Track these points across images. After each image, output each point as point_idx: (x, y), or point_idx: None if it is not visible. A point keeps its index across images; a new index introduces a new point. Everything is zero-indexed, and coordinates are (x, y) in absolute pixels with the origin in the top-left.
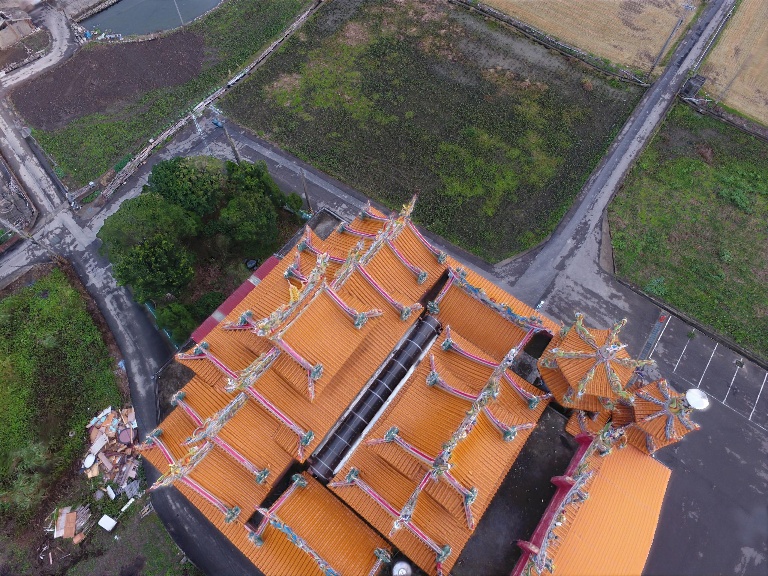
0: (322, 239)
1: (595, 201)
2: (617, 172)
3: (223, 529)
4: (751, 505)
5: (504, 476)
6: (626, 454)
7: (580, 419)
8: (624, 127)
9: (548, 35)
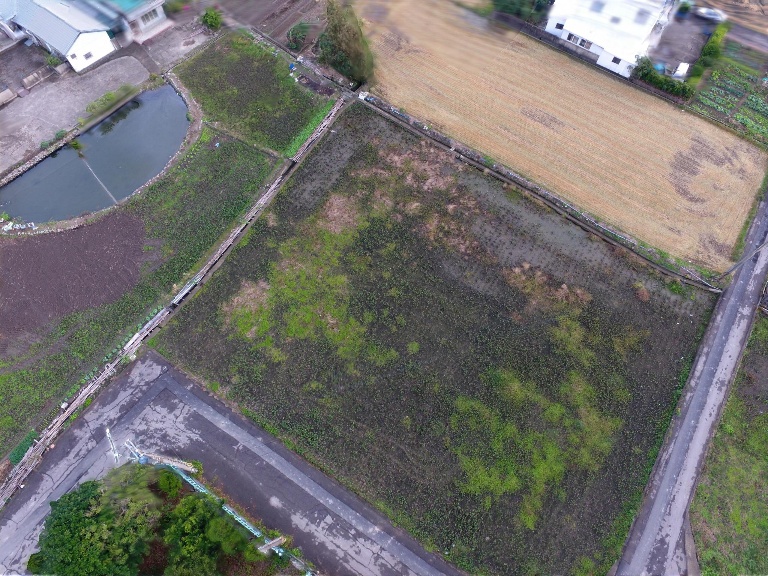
0: None
1: (672, 499)
2: (696, 445)
3: None
4: None
5: None
6: None
7: None
8: (696, 364)
9: (585, 213)
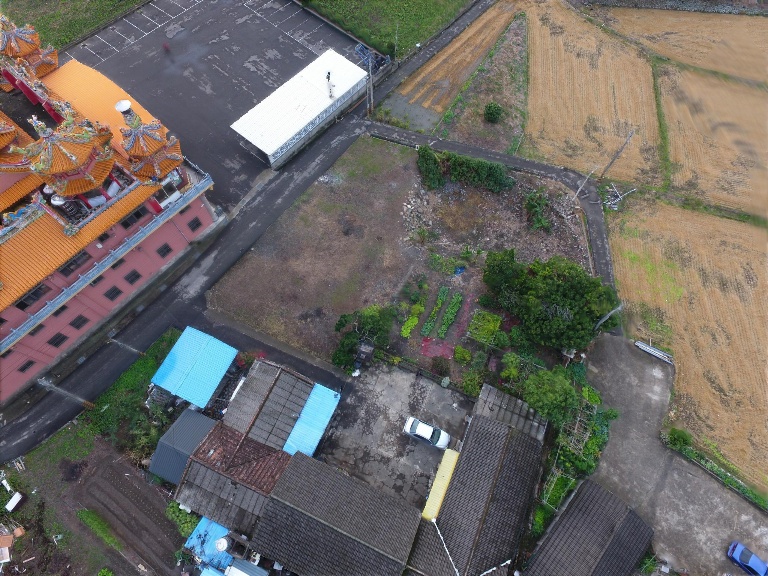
0: None
1: None
2: None
3: None
4: (164, 65)
5: (18, 127)
6: (53, 76)
7: (2, 82)
8: None
9: None
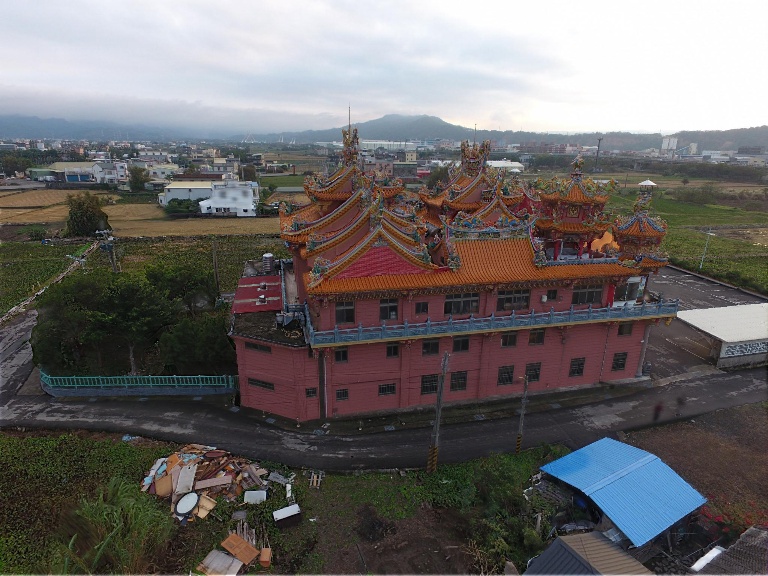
0: None
1: None
2: None
3: (429, 282)
4: None
5: None
6: None
7: None
8: None
9: (274, 233)
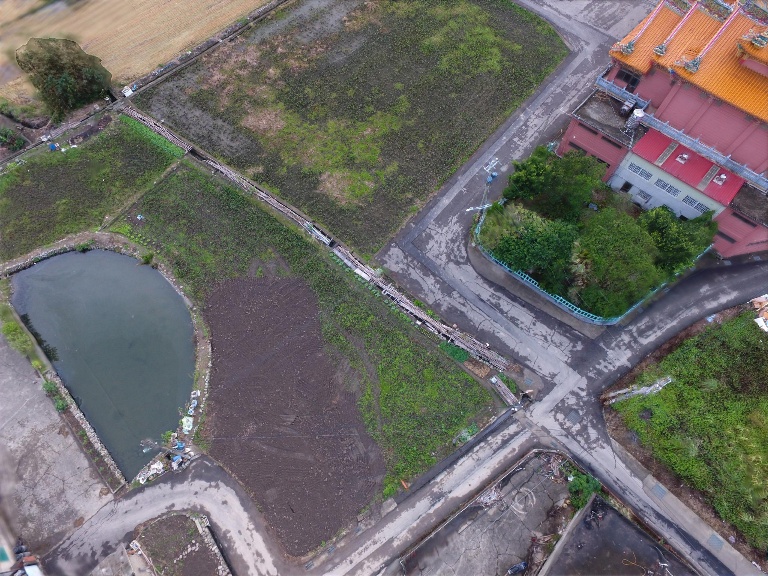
0: (608, 115)
1: None
2: None
3: None
4: None
5: None
6: None
7: None
8: None
9: None
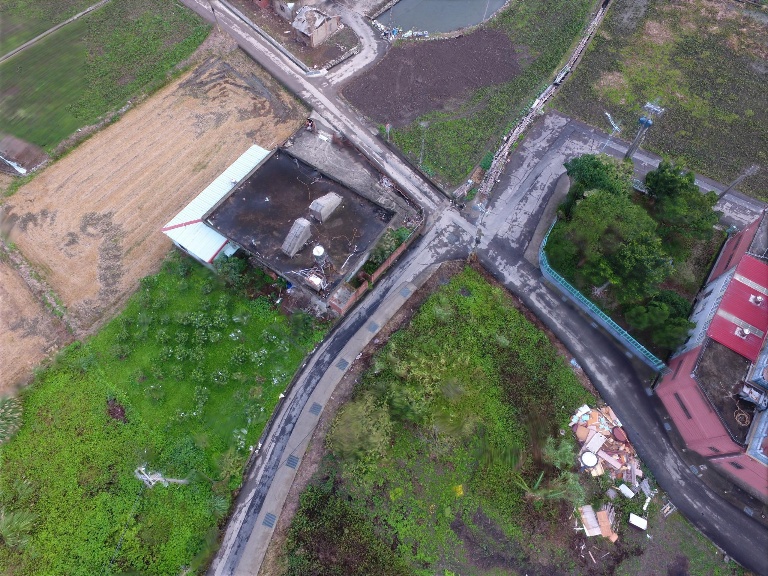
0: None
1: None
2: None
3: None
4: None
5: None
6: None
7: None
8: None
9: None
